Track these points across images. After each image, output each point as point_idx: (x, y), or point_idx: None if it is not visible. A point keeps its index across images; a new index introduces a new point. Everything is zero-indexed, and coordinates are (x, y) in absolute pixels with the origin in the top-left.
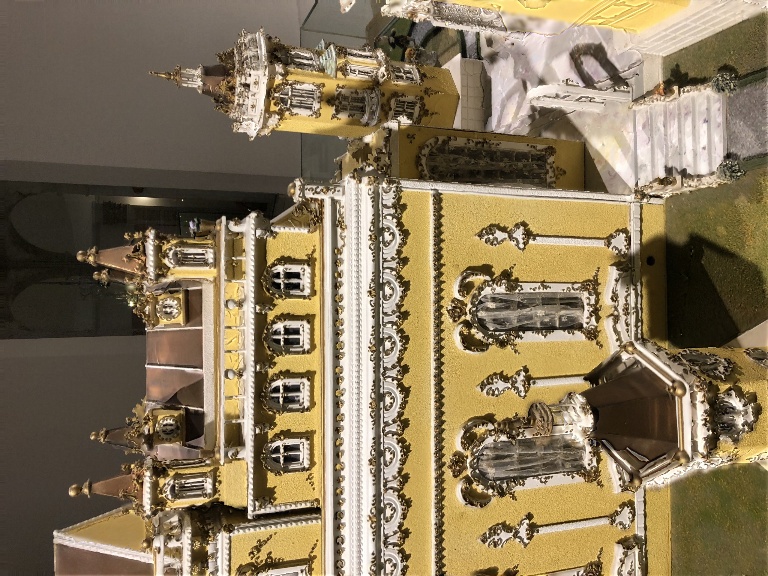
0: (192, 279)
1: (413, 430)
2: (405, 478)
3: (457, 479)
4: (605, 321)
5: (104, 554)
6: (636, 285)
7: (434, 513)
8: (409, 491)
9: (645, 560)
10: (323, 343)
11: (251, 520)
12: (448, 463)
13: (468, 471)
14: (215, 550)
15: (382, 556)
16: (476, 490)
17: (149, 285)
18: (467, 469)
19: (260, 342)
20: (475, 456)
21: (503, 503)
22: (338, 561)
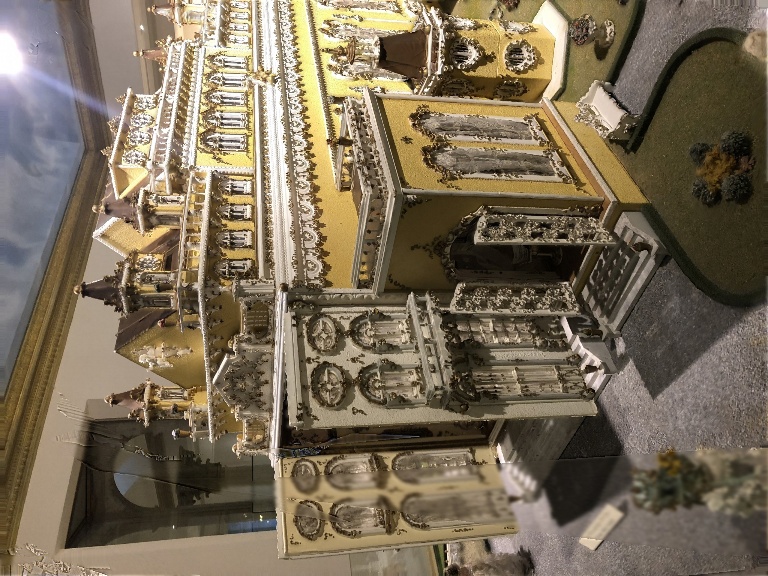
0: (195, 12)
1: (298, 22)
2: (294, 31)
3: None
4: (404, 11)
5: None
6: (420, 3)
7: None
8: None
9: None
10: (251, 5)
11: None
12: None
13: None
14: (198, 52)
15: None
16: None
17: (177, 26)
18: None
19: (224, 15)
20: None
21: None
22: (260, 50)
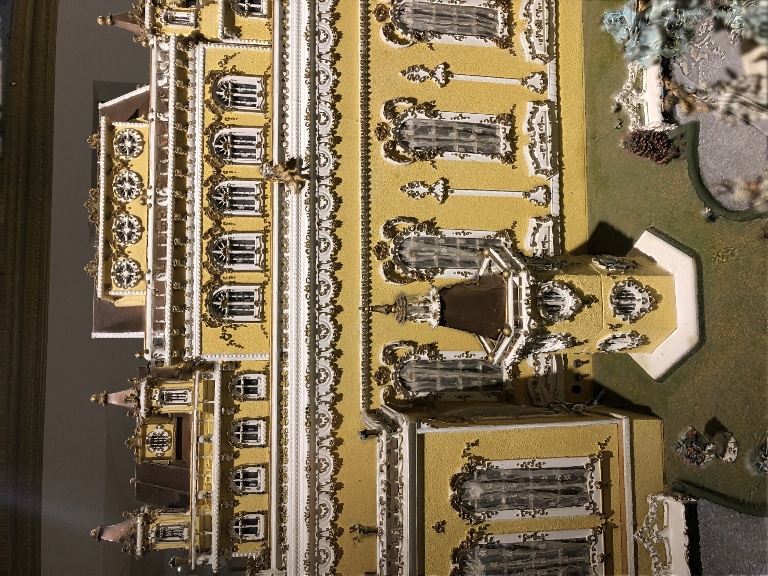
0: None
1: None
2: (337, 16)
3: (381, 25)
4: None
5: (128, 99)
6: None
7: (360, 43)
8: (340, 26)
9: (558, 123)
10: None
11: (221, 42)
12: (373, 11)
13: (390, 19)
14: (194, 57)
15: (316, 67)
16: (398, 36)
17: None
18: (389, 18)
19: None
20: (396, 9)
21: (421, 50)
22: (284, 71)
